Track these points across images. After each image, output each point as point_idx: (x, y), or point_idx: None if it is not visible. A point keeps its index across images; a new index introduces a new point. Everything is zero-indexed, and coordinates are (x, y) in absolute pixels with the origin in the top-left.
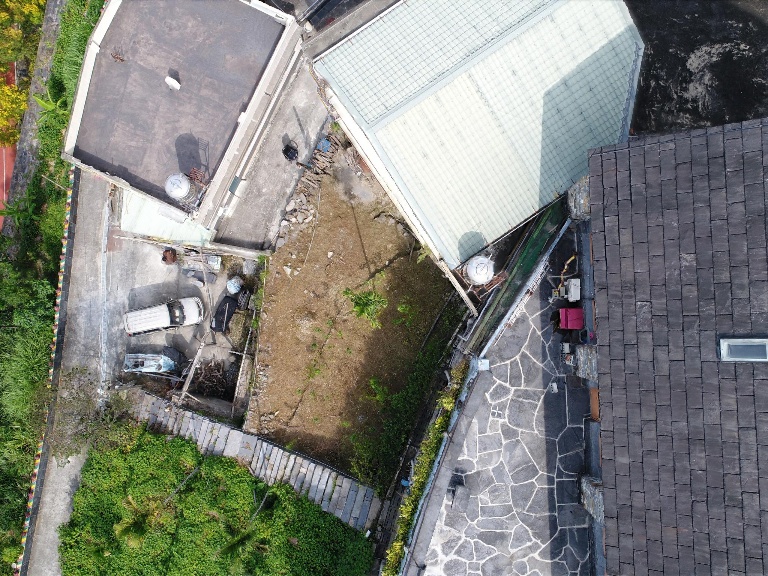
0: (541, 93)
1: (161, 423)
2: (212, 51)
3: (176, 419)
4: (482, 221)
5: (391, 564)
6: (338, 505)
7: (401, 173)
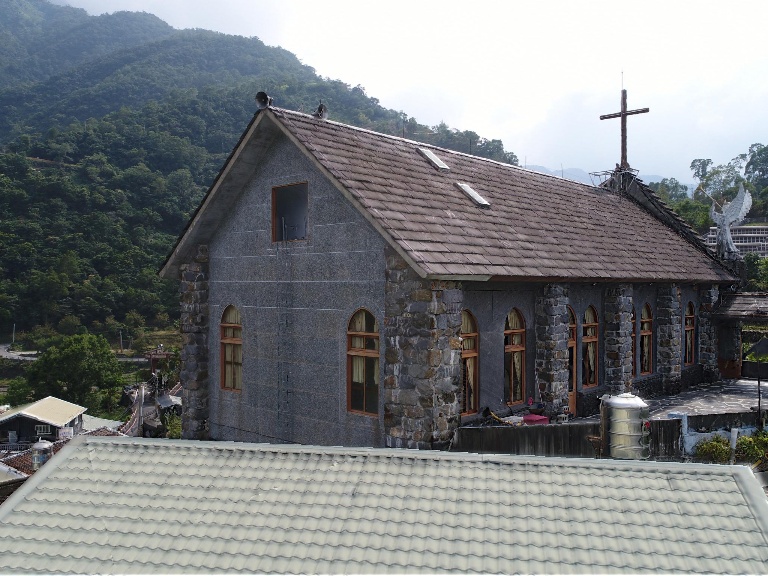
0: None
1: None
2: None
3: None
4: None
5: None
6: None
7: None
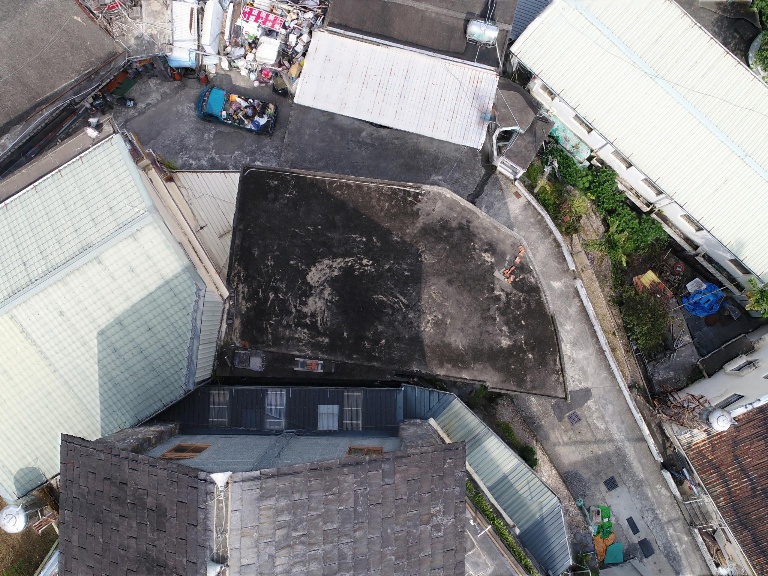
0: (94, 333)
1: None
2: None
3: None
4: (39, 457)
5: None
6: None
7: None
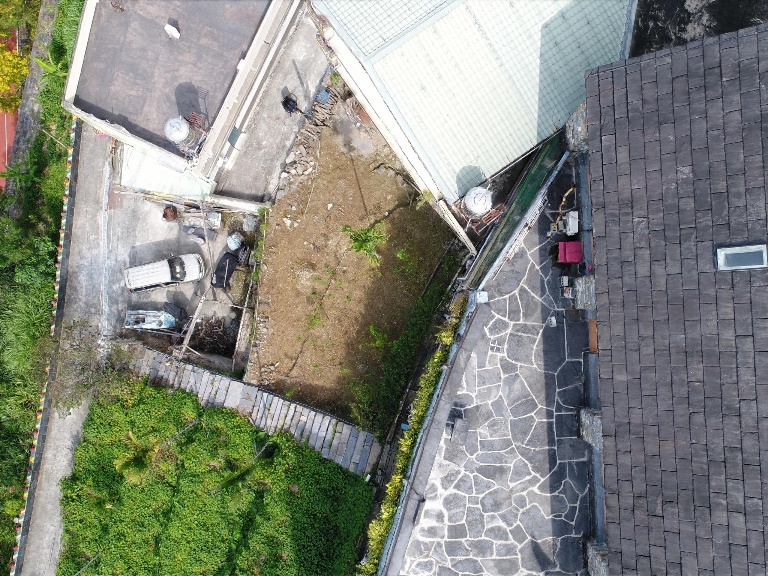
0: (539, 26)
1: (162, 377)
2: (211, 0)
3: (177, 373)
4: (480, 155)
5: (390, 497)
6: (338, 451)
7: (399, 106)
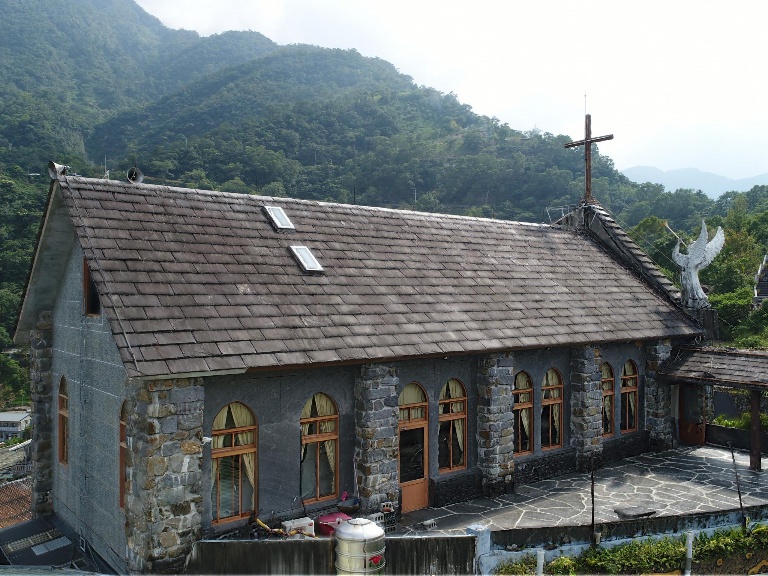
0: None
1: None
2: None
3: None
4: None
5: None
6: None
7: None
